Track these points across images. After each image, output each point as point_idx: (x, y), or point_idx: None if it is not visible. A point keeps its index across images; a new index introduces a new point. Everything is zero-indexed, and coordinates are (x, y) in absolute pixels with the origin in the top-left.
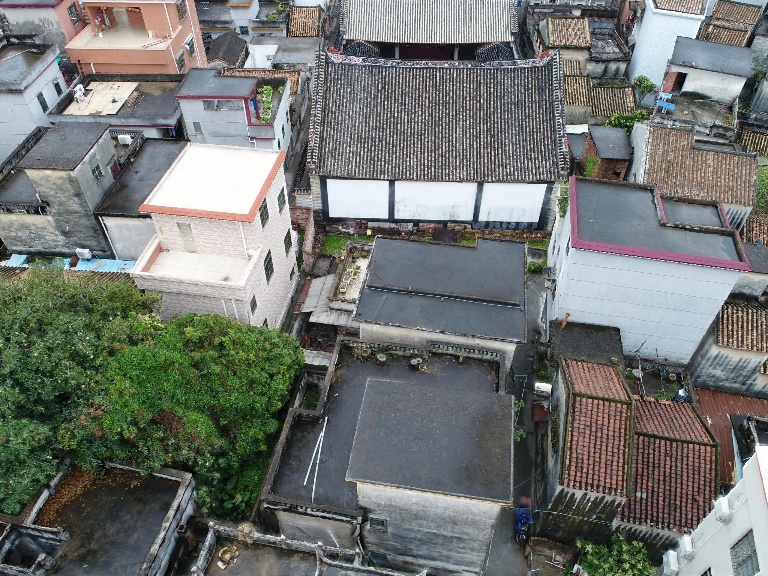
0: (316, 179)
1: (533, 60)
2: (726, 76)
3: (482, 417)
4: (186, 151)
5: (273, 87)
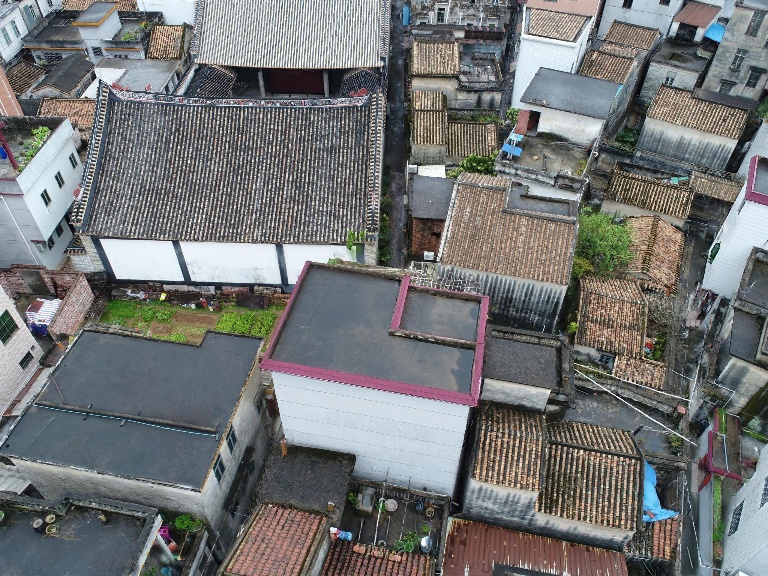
0: (87, 238)
1: (350, 99)
2: (581, 116)
3: None
4: None
5: (52, 128)
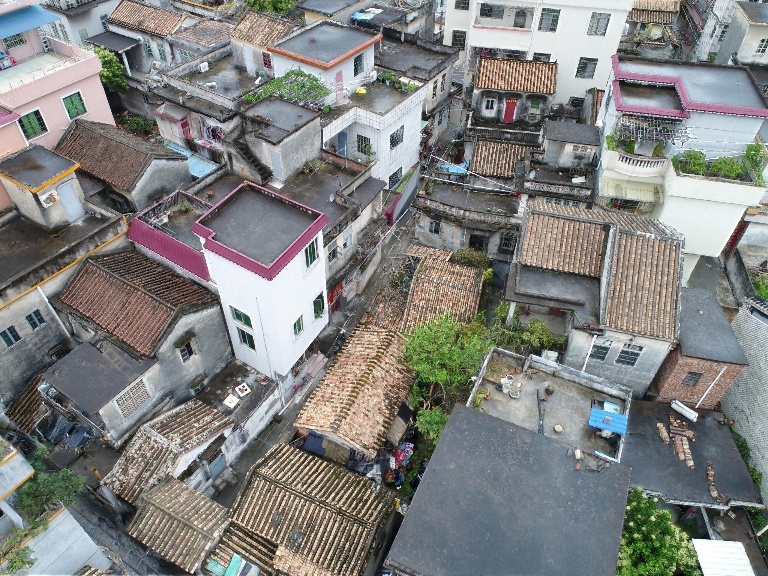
0: None
1: None
2: None
3: (763, 17)
4: None
5: None
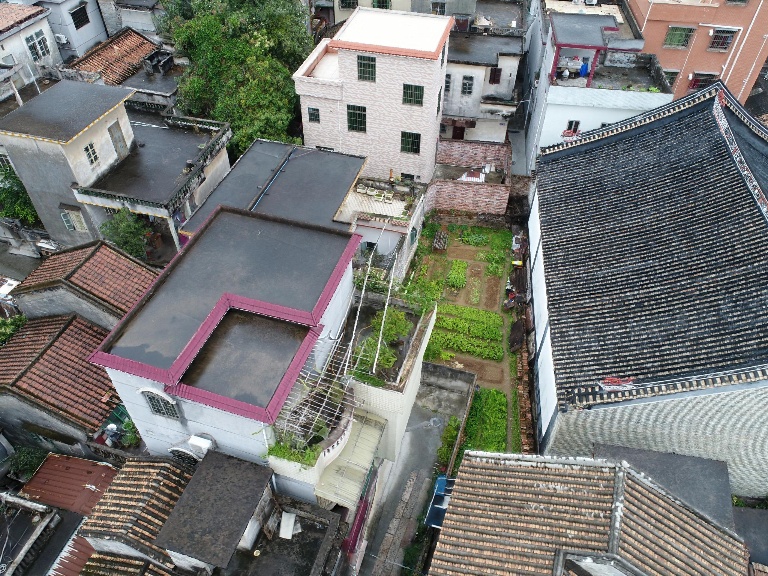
0: None
1: None
2: None
3: (60, 126)
4: (440, 18)
5: None
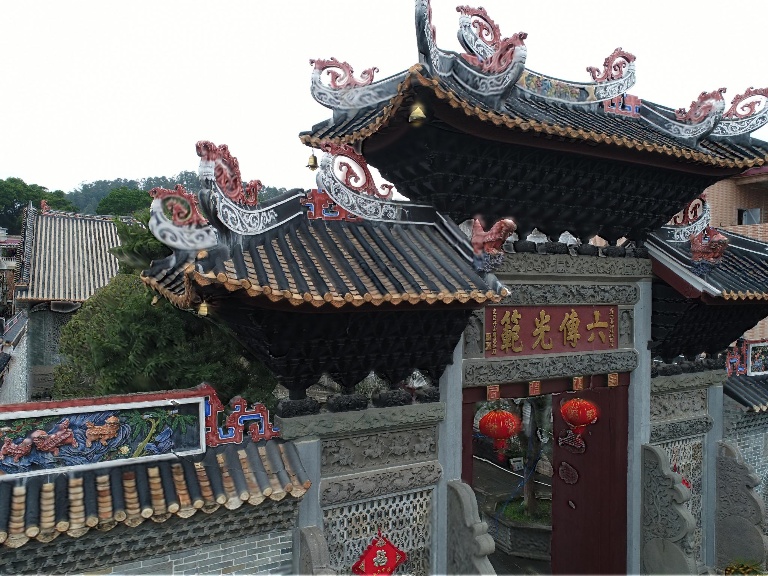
0: None
1: None
2: None
3: None
4: None
5: None
